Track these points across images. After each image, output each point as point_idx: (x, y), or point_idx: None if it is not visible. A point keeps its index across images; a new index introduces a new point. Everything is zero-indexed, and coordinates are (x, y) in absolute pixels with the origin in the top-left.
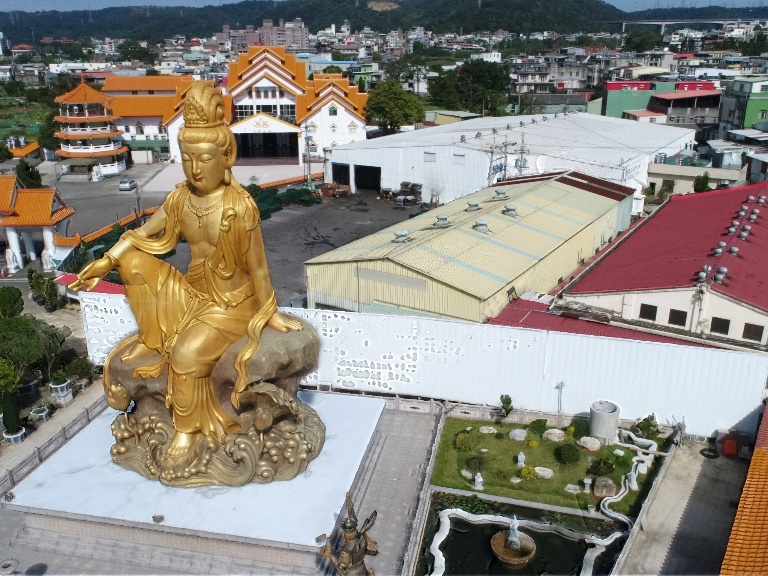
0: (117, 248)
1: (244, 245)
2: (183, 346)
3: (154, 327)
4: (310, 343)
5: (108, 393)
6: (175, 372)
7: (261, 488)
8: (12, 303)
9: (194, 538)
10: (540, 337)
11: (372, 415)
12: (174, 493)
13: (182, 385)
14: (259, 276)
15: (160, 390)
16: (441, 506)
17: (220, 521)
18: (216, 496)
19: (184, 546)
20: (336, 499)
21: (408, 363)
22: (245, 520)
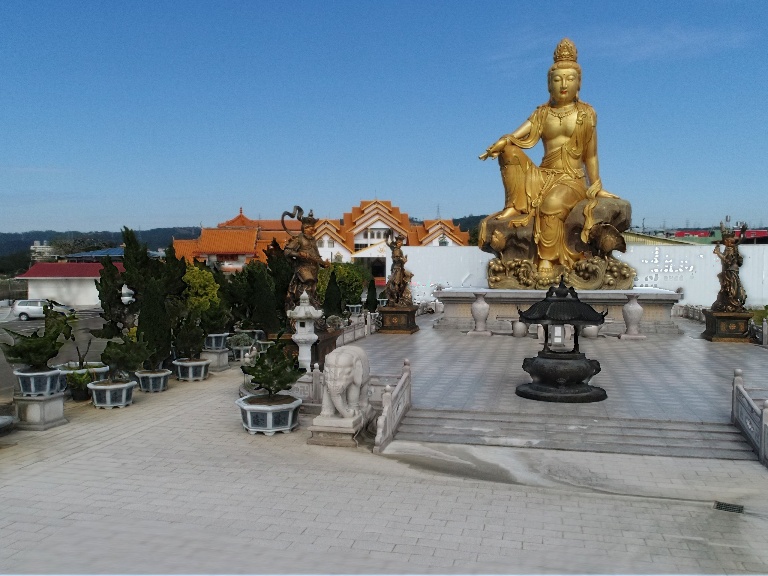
0: None
1: (588, 136)
2: (553, 196)
3: (522, 195)
4: (628, 206)
5: (491, 238)
6: (546, 214)
7: None
8: None
9: None
10: (758, 249)
11: None
12: None
13: (551, 222)
14: (593, 161)
15: (526, 236)
16: None
17: None
18: None
19: None
20: None
21: (651, 283)
22: None
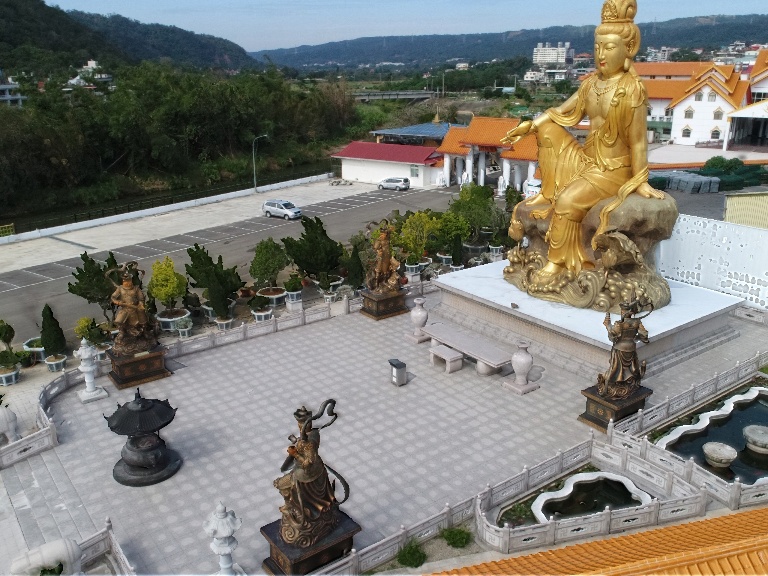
0: (539, 119)
1: (628, 120)
2: (565, 193)
3: (552, 182)
4: (666, 210)
5: None
6: (555, 212)
7: (596, 313)
8: (486, 198)
9: (536, 329)
10: None
11: (723, 303)
12: (533, 300)
13: (558, 223)
14: (637, 149)
15: (545, 230)
16: (759, 386)
17: (555, 318)
18: (560, 308)
19: (528, 334)
20: (650, 332)
21: None
22: (572, 322)
